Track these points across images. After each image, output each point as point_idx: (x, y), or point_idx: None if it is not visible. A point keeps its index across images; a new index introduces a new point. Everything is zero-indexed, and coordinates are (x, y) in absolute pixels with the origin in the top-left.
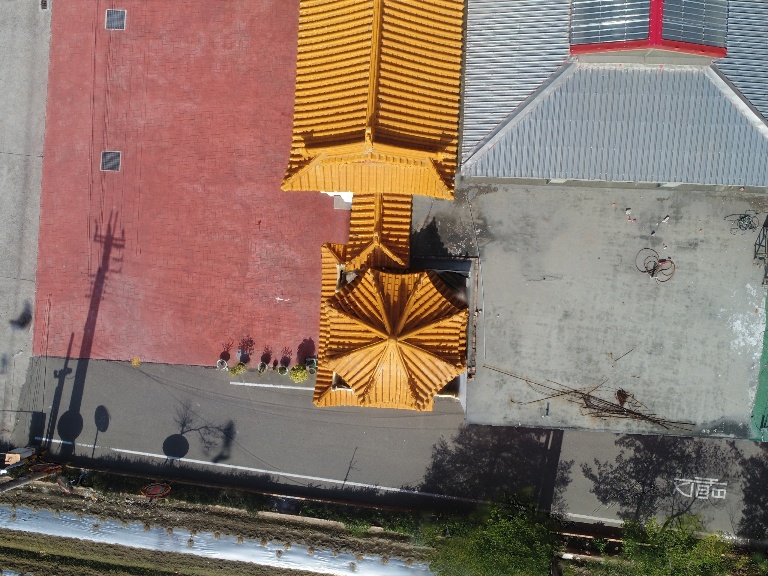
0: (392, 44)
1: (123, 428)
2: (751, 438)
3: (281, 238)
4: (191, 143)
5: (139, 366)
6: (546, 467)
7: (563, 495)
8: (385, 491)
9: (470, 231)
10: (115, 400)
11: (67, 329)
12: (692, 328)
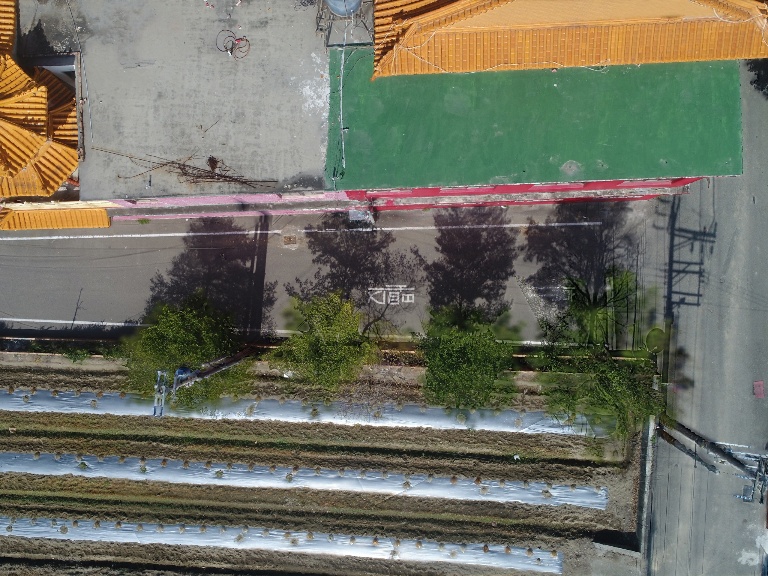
0: None
1: None
2: (326, 189)
3: None
4: None
5: None
6: (253, 290)
7: (271, 314)
8: (111, 326)
9: (72, 29)
10: None
11: None
12: (268, 97)
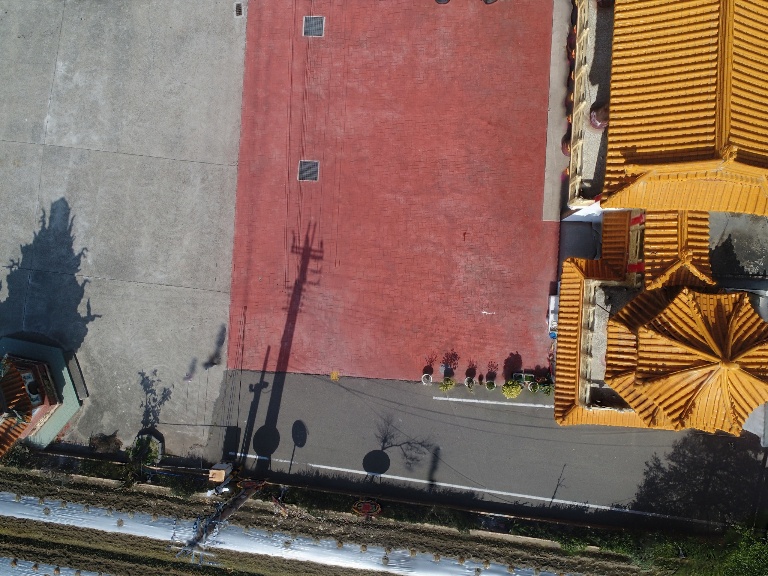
0: (735, 58)
1: (321, 443)
2: None
3: (487, 250)
4: (393, 153)
5: (338, 380)
6: (763, 485)
7: None
8: (595, 509)
9: (767, 249)
10: (313, 415)
11: (263, 342)
12: None
